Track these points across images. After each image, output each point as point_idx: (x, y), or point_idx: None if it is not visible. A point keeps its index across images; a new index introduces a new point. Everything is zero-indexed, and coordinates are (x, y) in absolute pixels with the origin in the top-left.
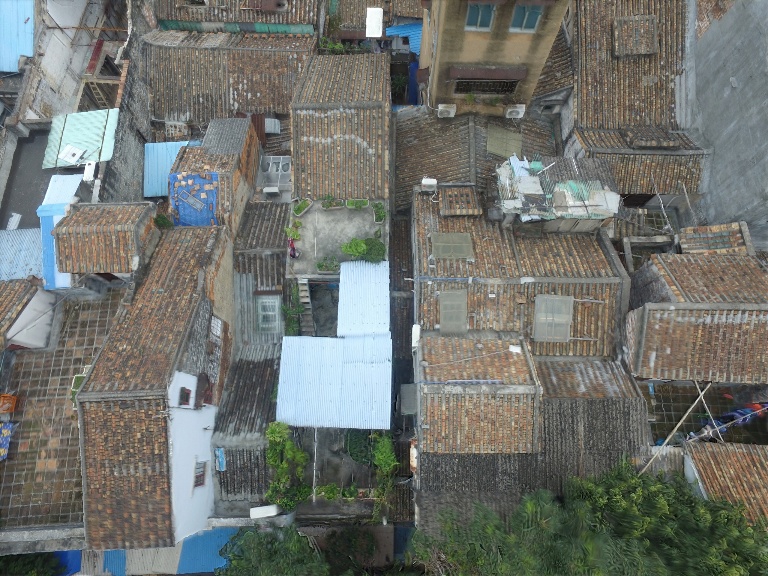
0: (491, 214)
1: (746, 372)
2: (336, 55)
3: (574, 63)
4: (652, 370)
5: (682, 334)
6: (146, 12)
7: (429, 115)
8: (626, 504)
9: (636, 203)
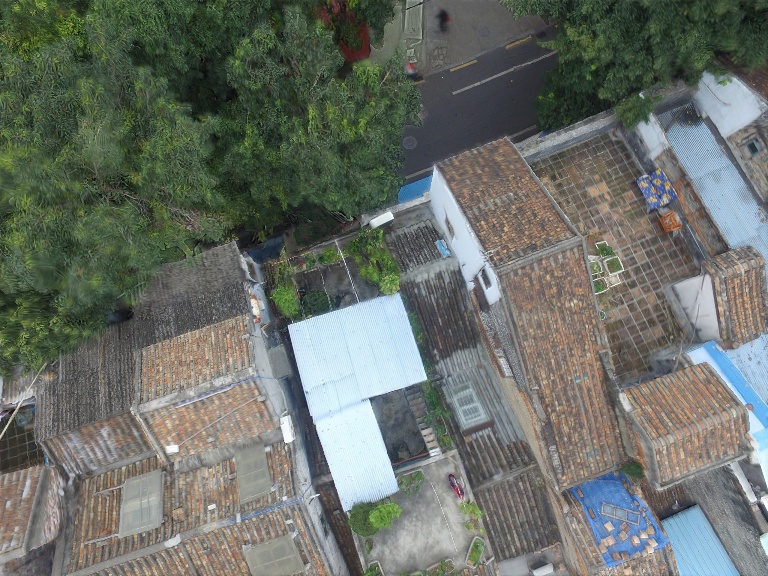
0: None
1: None
2: None
3: None
4: (29, 476)
5: None
6: None
7: None
8: None
9: None
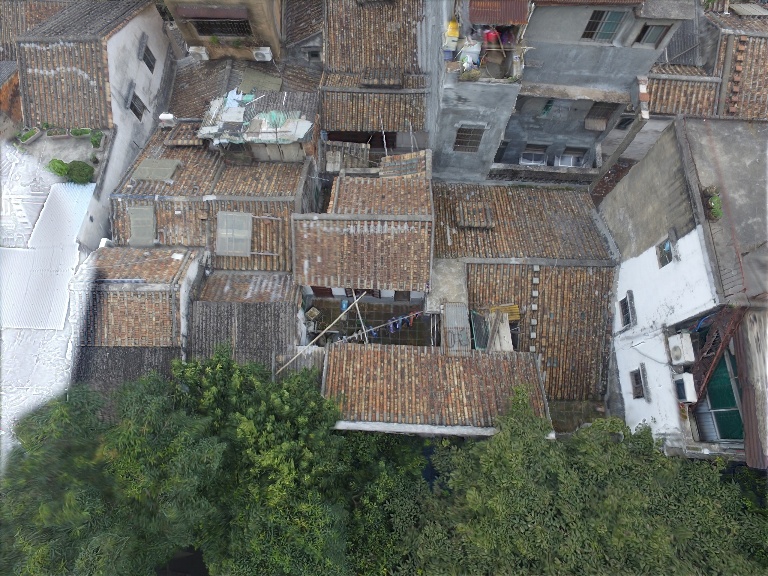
0: (212, 145)
1: (391, 280)
2: (102, 1)
3: (322, 9)
4: (306, 278)
5: (330, 243)
6: None
7: (200, 61)
8: (199, 377)
9: (386, 144)
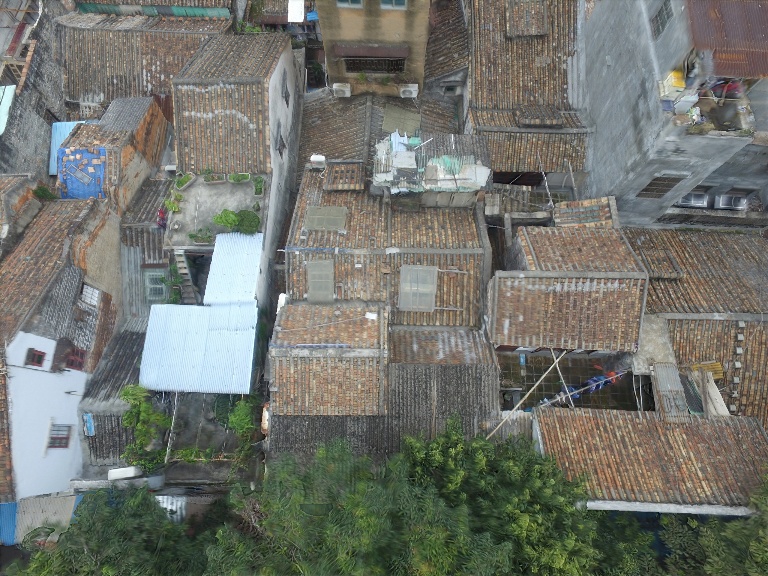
0: (373, 189)
1: (597, 339)
2: None
3: (468, 44)
4: (506, 337)
5: (534, 302)
6: None
7: (332, 96)
8: (443, 459)
9: (532, 182)
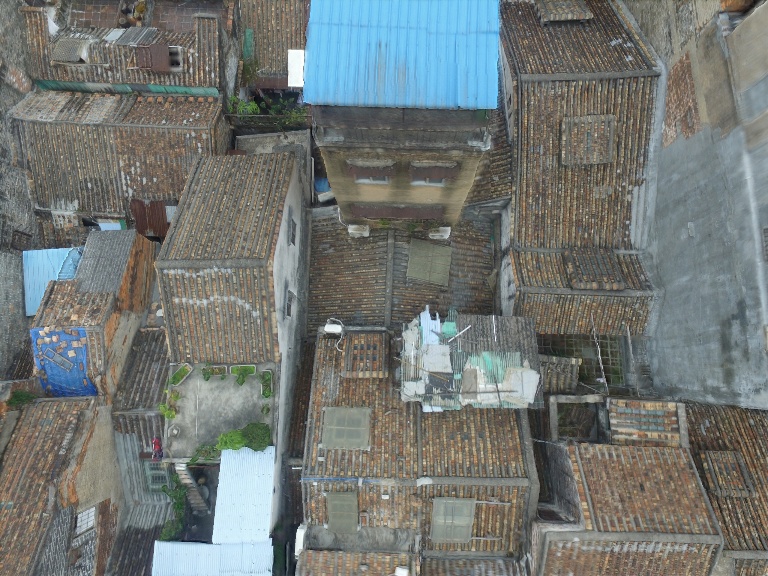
0: (399, 375)
1: None
2: (229, 157)
3: (513, 170)
4: None
5: (587, 560)
6: (12, 77)
7: None
8: None
9: None
